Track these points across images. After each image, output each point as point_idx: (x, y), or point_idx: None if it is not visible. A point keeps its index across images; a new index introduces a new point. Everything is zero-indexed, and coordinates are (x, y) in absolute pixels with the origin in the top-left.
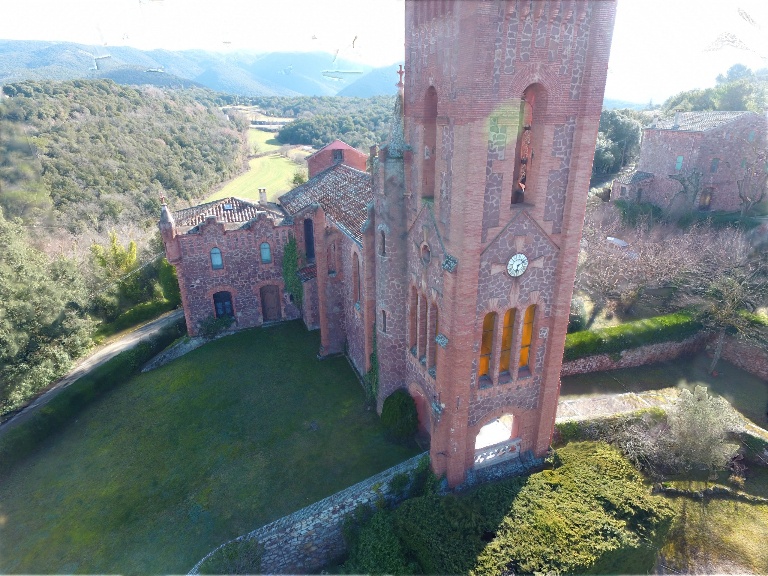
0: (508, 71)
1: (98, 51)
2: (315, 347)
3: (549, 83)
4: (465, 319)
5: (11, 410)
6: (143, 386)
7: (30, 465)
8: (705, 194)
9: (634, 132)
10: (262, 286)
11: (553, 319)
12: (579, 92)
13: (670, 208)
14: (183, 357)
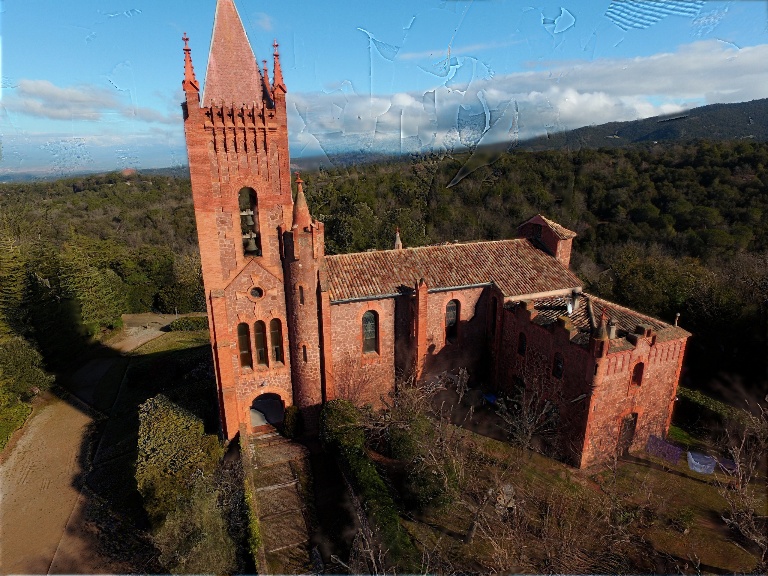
0: None
1: (667, 114)
2: None
3: None
4: None
5: None
6: None
7: None
8: None
9: None
10: None
11: None
12: None
13: None
14: None
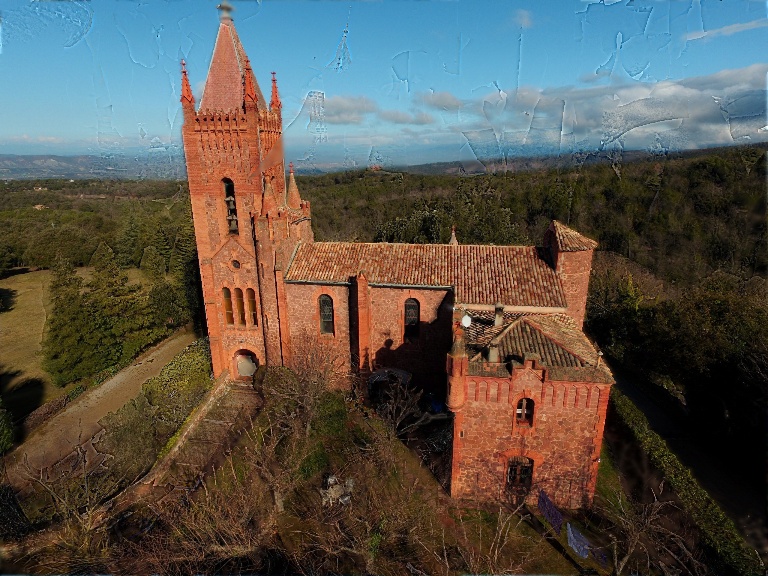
0: None
1: None
2: None
3: None
4: None
5: None
6: None
7: None
8: None
9: None
10: None
11: None
12: None
13: None
14: None
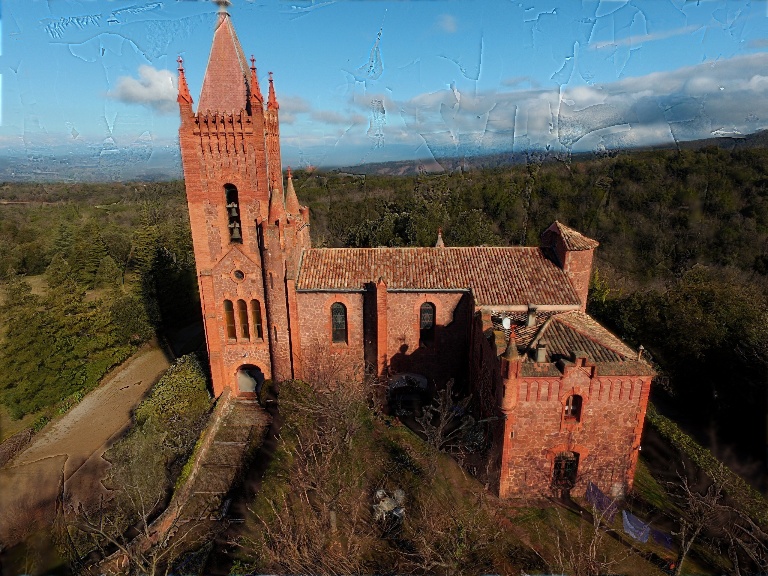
0: None
1: None
2: None
3: None
4: None
5: None
6: None
7: None
8: None
9: None
10: None
11: None
12: None
13: None
14: None
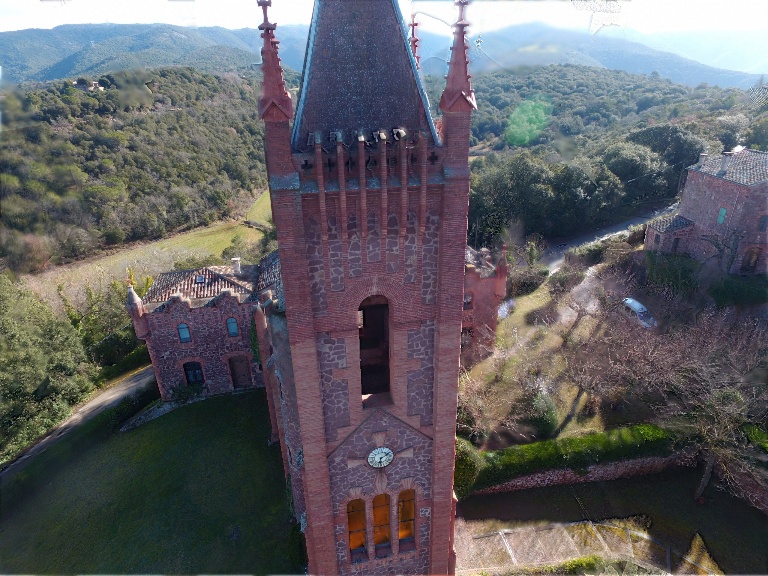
0: (337, 288)
1: None
2: (271, 427)
3: (392, 293)
4: (319, 512)
5: (7, 460)
6: (114, 450)
7: (0, 530)
8: (750, 254)
9: (696, 152)
10: (231, 357)
11: (432, 503)
12: (435, 296)
13: (699, 274)
14: (156, 420)
